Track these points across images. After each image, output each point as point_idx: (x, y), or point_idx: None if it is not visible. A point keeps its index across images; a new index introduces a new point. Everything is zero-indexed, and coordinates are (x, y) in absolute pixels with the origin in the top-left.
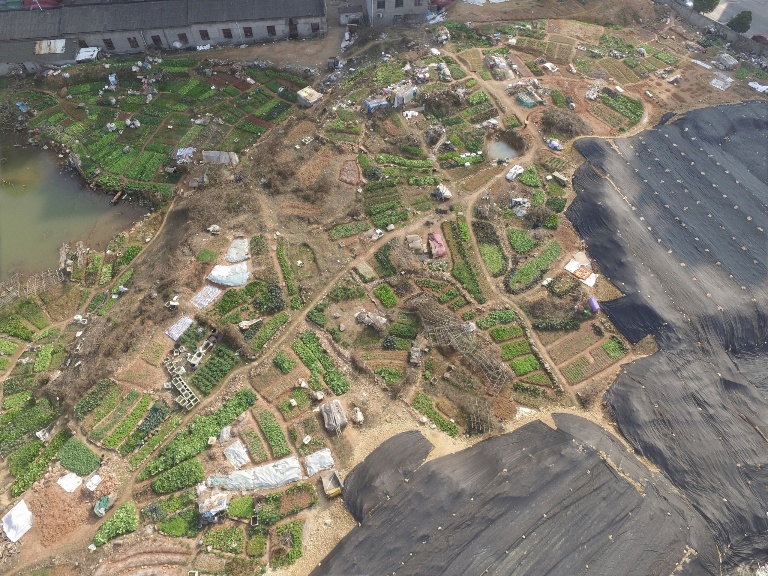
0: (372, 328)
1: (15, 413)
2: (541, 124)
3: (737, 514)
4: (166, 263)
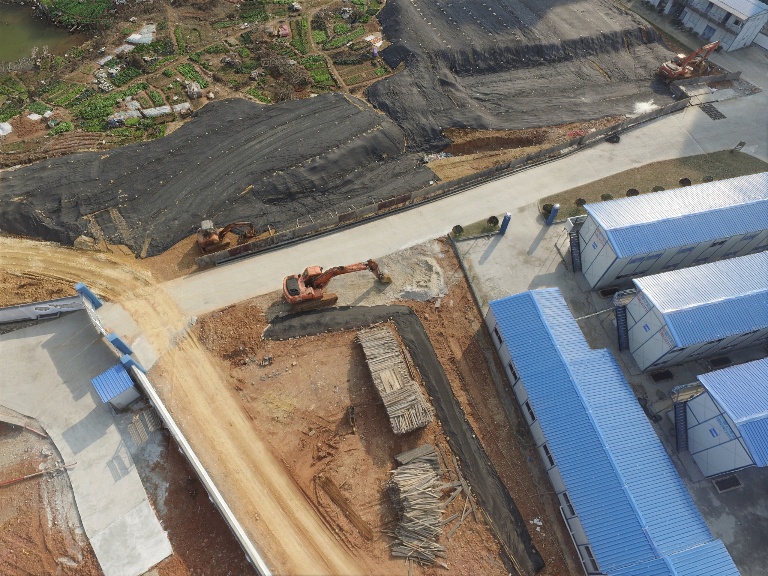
0: (230, 64)
1: None
2: None
3: (421, 127)
4: None
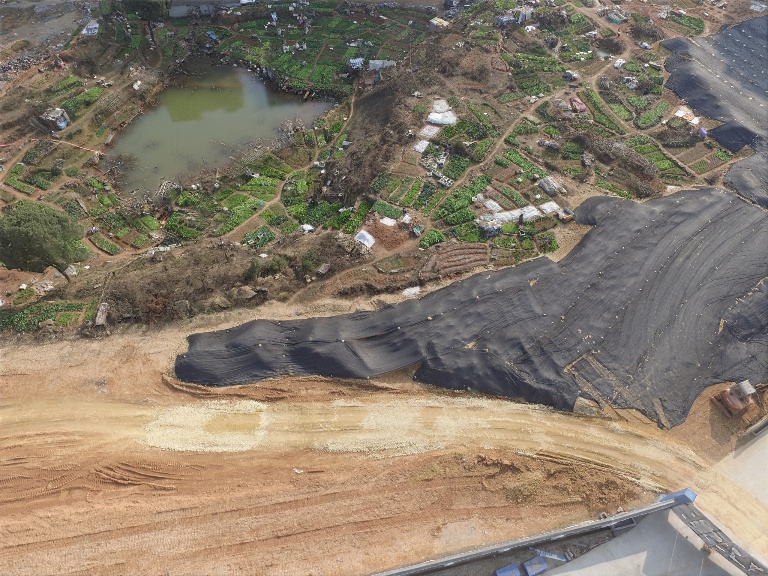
0: (551, 148)
1: (303, 212)
2: (631, 33)
3: None
4: (382, 121)
